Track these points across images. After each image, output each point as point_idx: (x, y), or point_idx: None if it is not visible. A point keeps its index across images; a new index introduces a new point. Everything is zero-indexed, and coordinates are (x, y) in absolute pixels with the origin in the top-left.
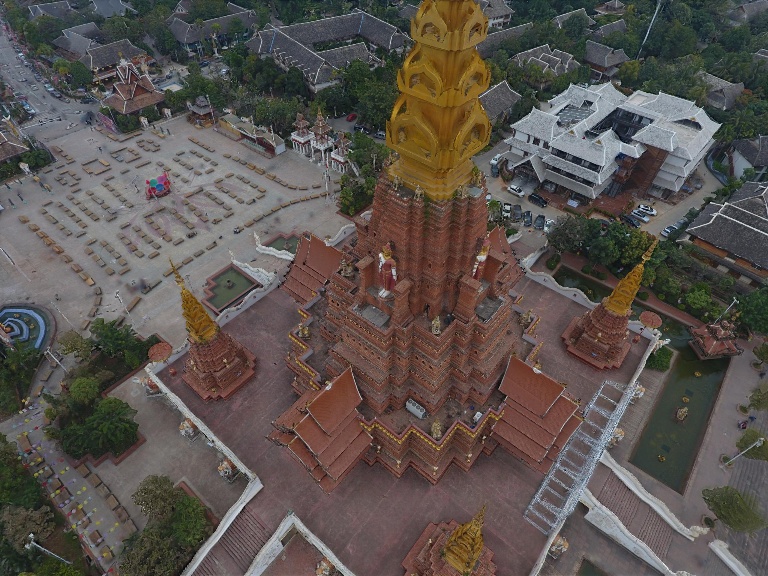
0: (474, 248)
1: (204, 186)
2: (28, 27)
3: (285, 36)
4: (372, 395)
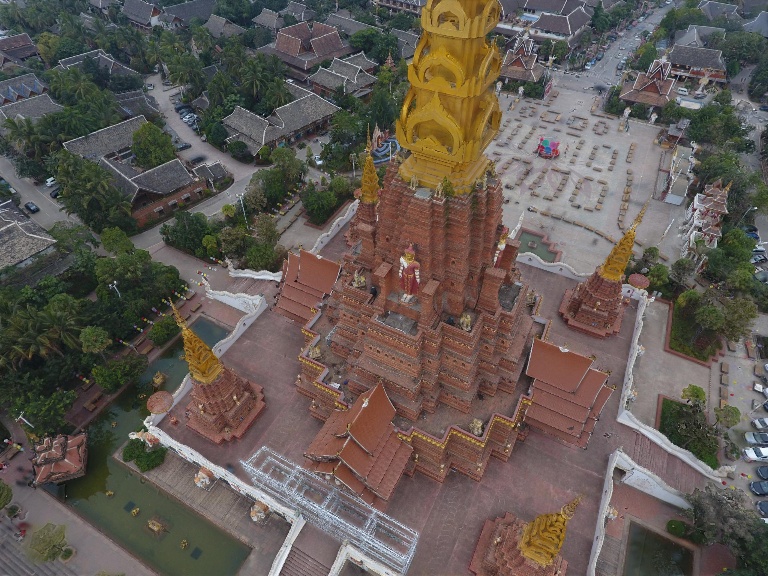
0: None
1: (575, 173)
2: (670, 12)
3: None
4: None
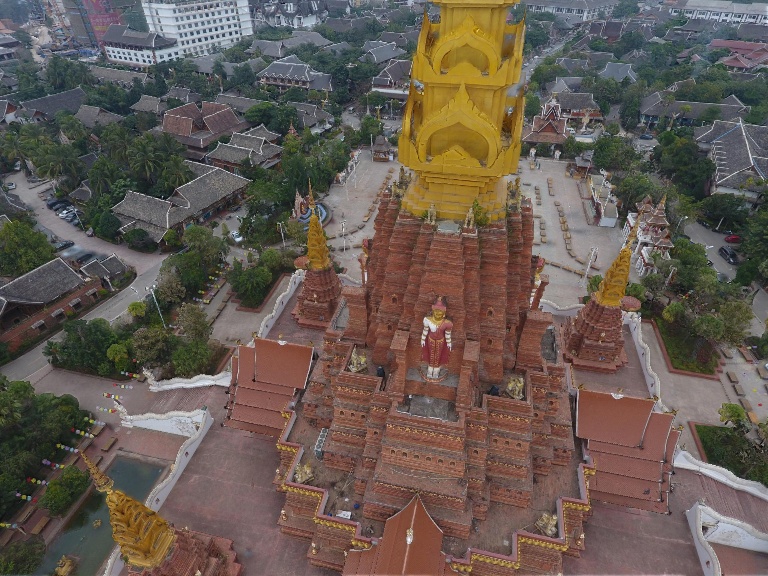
0: (429, 305)
1: None
2: (537, 68)
3: (742, 132)
4: (308, 390)
